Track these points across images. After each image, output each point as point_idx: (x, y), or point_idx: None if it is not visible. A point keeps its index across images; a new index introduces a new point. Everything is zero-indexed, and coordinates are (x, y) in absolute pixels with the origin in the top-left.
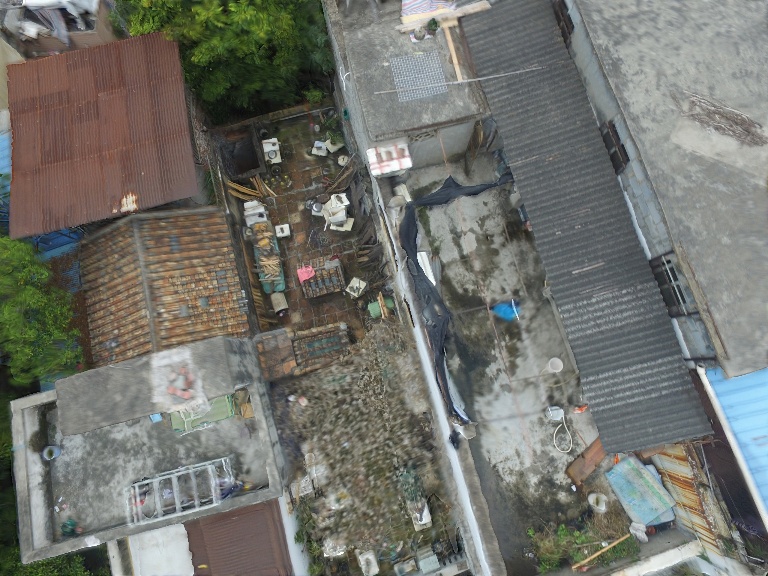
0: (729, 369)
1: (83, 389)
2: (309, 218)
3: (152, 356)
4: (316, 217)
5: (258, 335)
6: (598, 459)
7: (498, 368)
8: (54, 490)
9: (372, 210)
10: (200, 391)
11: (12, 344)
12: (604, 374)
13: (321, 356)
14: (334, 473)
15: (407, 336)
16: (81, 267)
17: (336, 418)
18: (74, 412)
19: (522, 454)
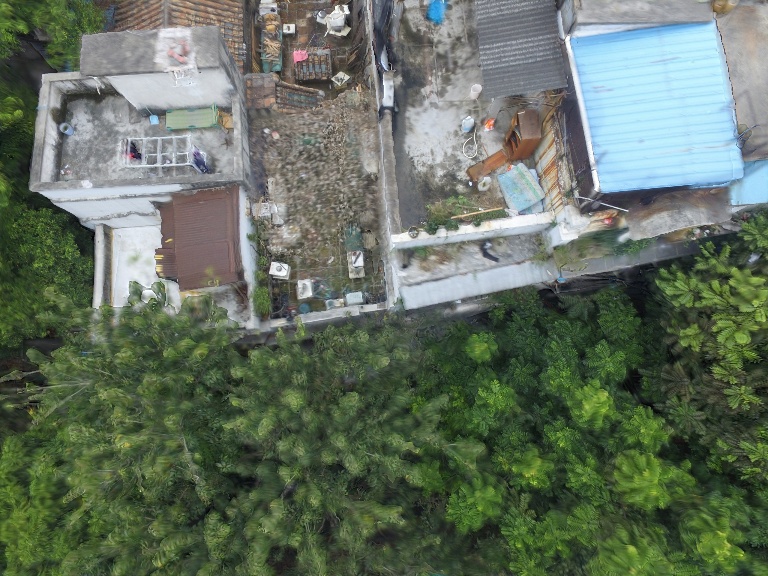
0: (580, 16)
1: (103, 44)
2: (314, 25)
3: (161, 30)
4: (320, 24)
5: (249, 74)
6: (495, 166)
7: (431, 90)
8: (63, 159)
9: (365, 7)
10: (193, 60)
11: (52, 26)
12: (498, 44)
13: (298, 106)
14: (289, 195)
15: (371, 101)
16: (116, 2)
17: (300, 154)
18: (93, 59)
19: (435, 153)
